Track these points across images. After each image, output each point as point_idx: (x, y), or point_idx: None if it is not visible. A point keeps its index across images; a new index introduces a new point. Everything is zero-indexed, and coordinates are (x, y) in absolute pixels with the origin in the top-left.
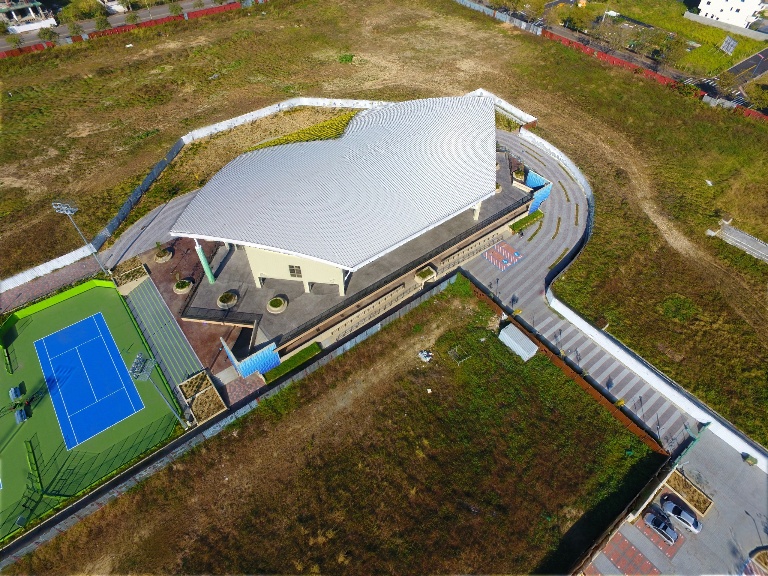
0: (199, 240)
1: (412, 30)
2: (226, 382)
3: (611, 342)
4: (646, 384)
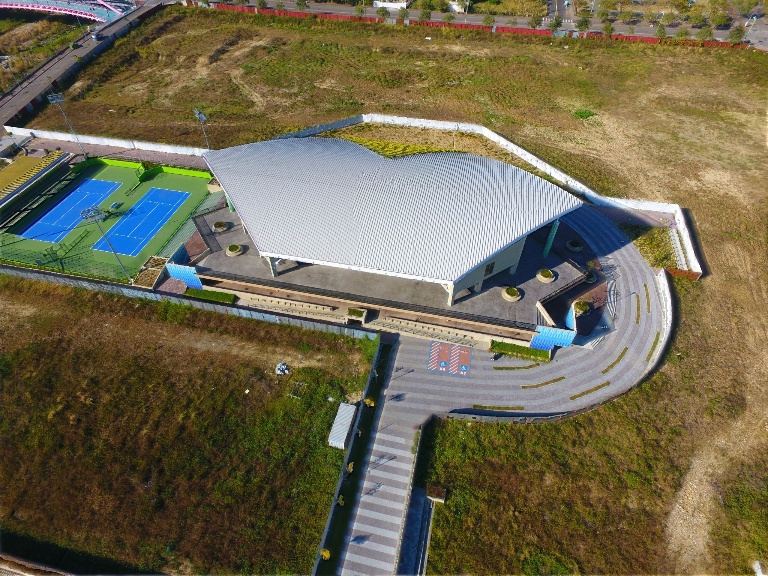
0: None
1: (704, 116)
2: None
3: (406, 509)
4: None
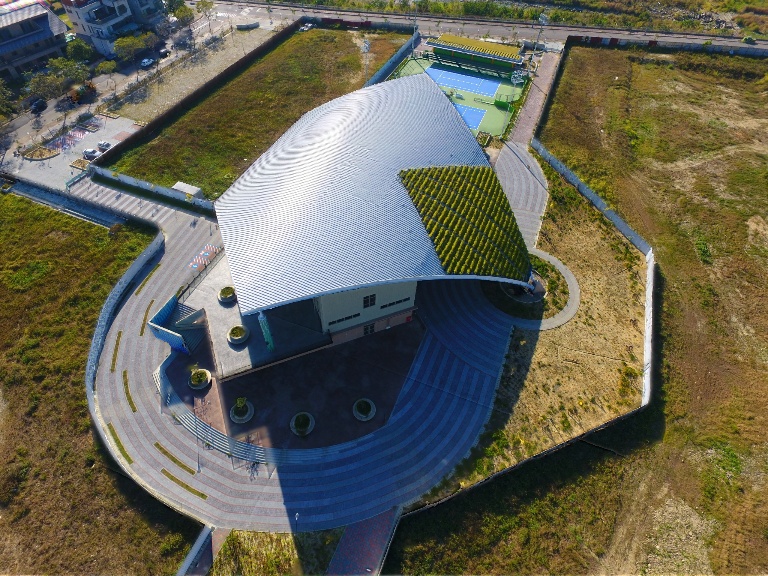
0: None
1: None
2: None
3: None
4: None
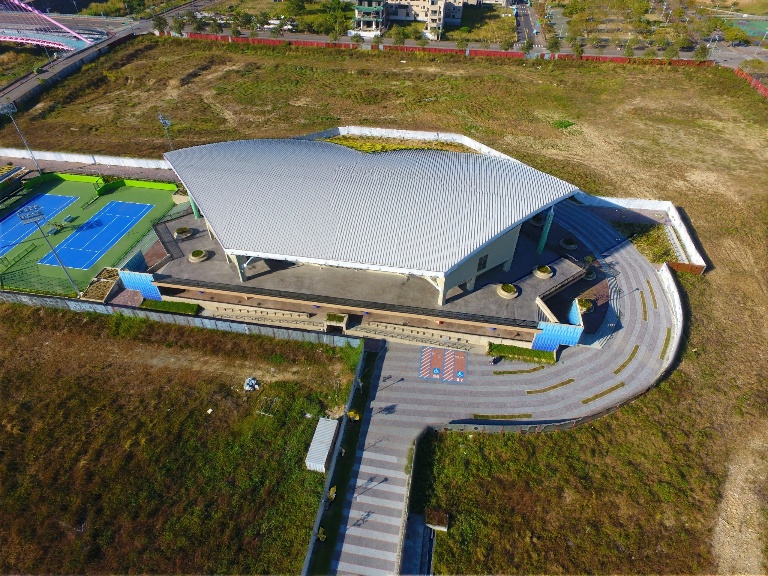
0: None
1: (681, 124)
2: None
3: None
4: None
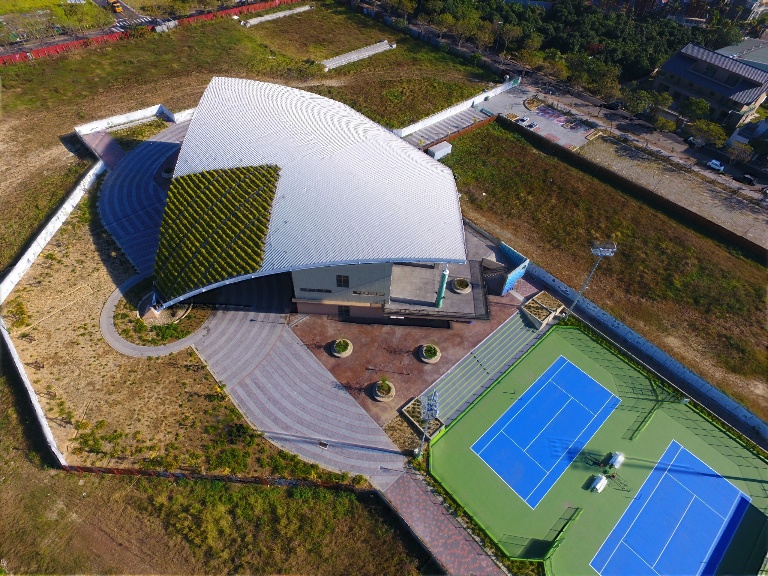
0: (349, 362)
1: None
2: (522, 297)
3: (434, 116)
4: (453, 116)
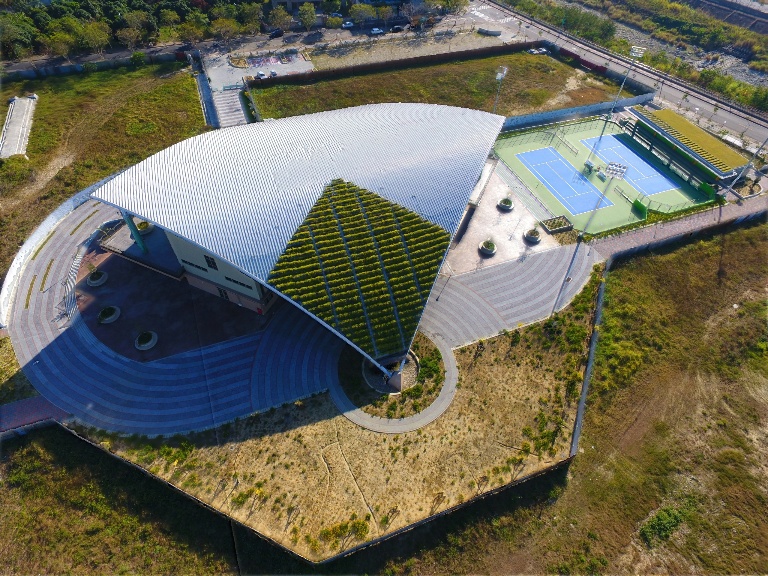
0: (501, 247)
1: None
2: None
3: None
4: (218, 106)
